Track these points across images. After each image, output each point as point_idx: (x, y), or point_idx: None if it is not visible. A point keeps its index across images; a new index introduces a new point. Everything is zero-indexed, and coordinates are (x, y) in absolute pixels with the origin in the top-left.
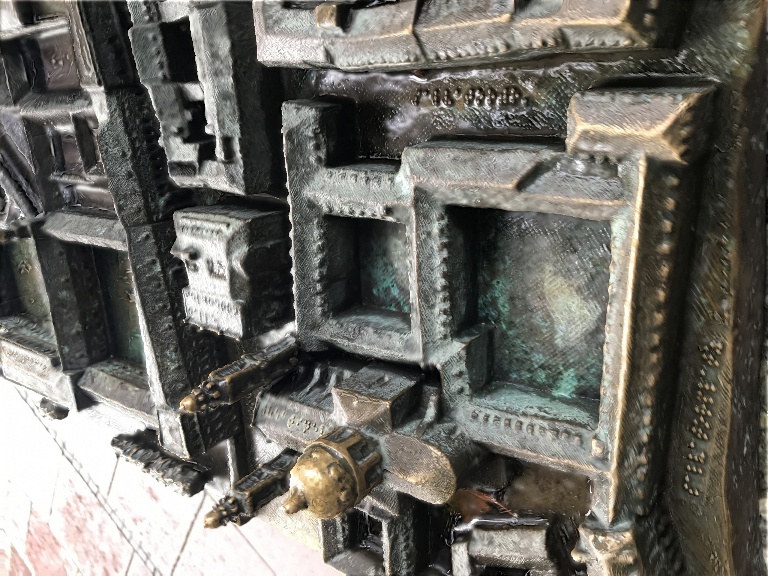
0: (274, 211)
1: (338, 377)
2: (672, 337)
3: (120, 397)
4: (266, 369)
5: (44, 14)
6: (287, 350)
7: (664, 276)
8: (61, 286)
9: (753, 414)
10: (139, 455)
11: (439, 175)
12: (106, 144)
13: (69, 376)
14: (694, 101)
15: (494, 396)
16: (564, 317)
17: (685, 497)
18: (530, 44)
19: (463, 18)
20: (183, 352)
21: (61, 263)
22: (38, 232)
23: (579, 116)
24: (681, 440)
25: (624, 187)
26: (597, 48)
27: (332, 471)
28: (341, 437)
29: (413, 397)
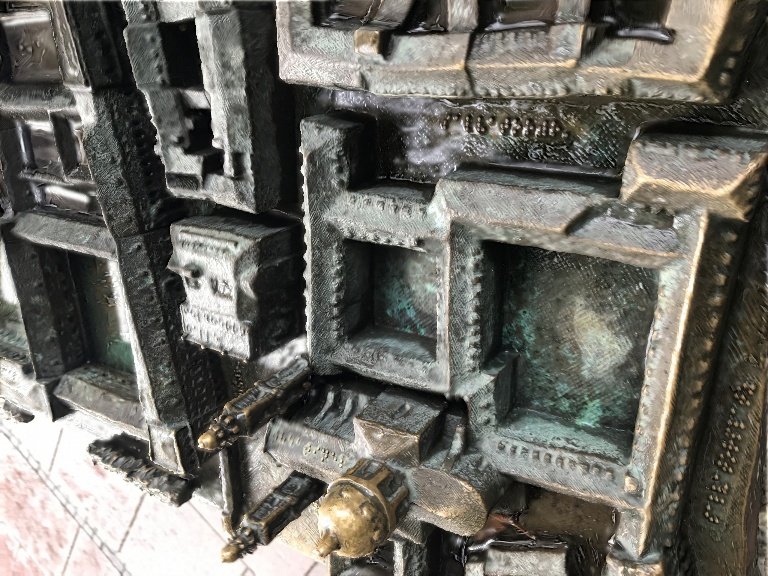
0: (282, 227)
1: (354, 402)
2: (710, 380)
3: (103, 409)
4: (282, 397)
5: (19, 2)
6: (301, 375)
7: (713, 327)
8: (34, 291)
9: (765, 440)
10: (120, 463)
11: (480, 212)
12: (94, 149)
13: (44, 385)
14: (762, 162)
15: (518, 425)
16: (592, 350)
17: (705, 524)
18: (593, 90)
19: (523, 59)
20: (177, 366)
21: (33, 267)
22: (8, 235)
23: (641, 168)
24: (705, 472)
25: (680, 239)
26: (662, 99)
27: (365, 511)
28: (368, 472)
29: (437, 427)
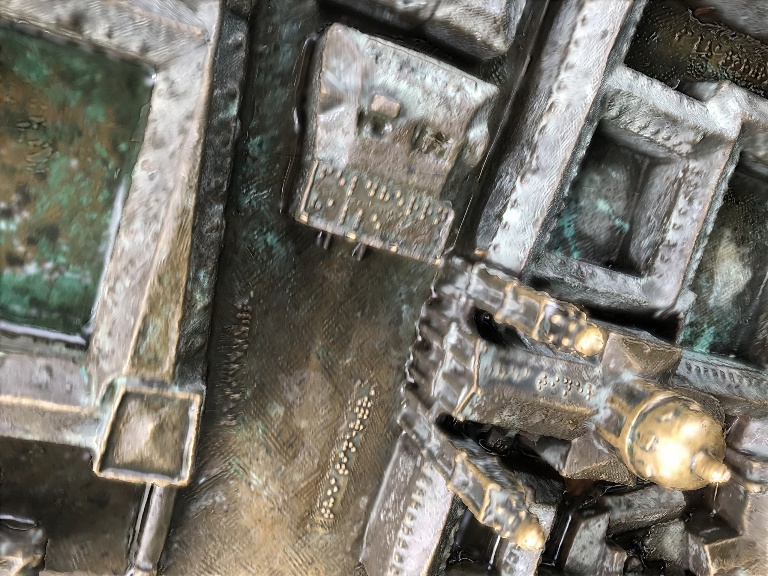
0: None
1: None
2: None
3: None
4: None
5: None
6: None
7: None
8: None
9: None
10: None
11: None
12: None
13: None
14: None
15: None
16: (723, 279)
17: None
18: None
19: None
20: (215, 278)
21: None
22: None
23: None
24: None
25: None
26: None
27: None
28: None
29: None
